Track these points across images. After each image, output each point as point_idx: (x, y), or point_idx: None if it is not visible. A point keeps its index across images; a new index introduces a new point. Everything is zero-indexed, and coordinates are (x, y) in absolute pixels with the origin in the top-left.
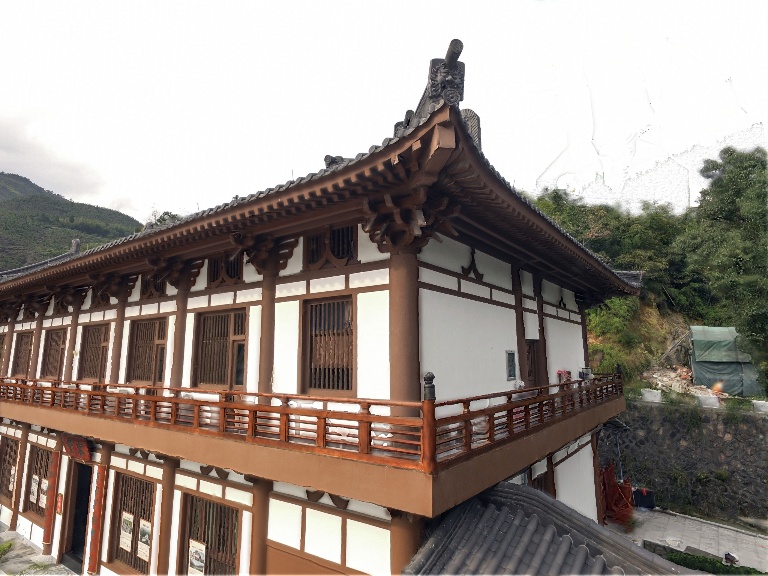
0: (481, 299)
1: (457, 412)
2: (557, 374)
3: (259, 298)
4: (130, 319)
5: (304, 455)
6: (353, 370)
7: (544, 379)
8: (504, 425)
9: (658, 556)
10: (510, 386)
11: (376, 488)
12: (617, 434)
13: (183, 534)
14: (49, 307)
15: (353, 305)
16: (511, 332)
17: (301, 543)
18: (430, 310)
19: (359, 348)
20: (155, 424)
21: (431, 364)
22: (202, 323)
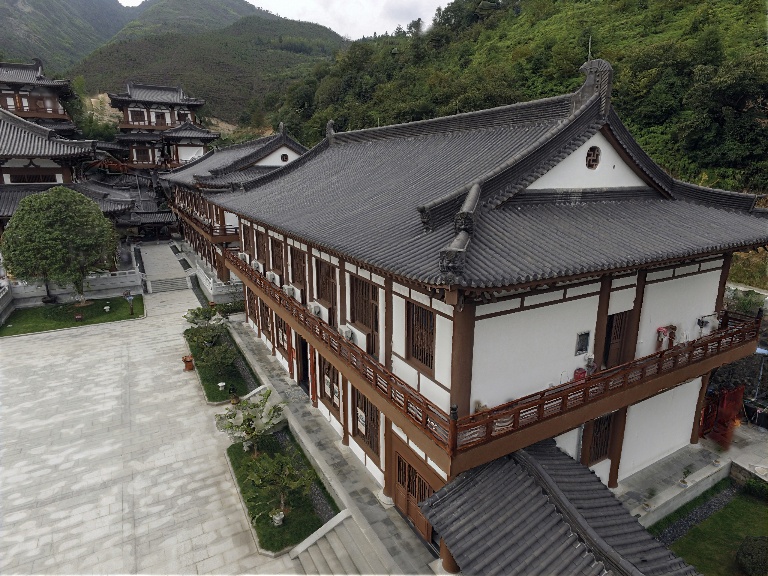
0: (550, 303)
1: (508, 392)
2: (656, 331)
3: (384, 285)
4: (315, 257)
5: (398, 412)
6: (433, 361)
7: (631, 342)
8: (533, 413)
9: (591, 529)
10: (578, 359)
11: (428, 448)
12: (763, 357)
13: (354, 403)
14: None
15: (434, 320)
16: (589, 316)
17: (407, 440)
18: (486, 332)
19: (436, 350)
20: (330, 349)
21: (484, 368)
22: (355, 282)
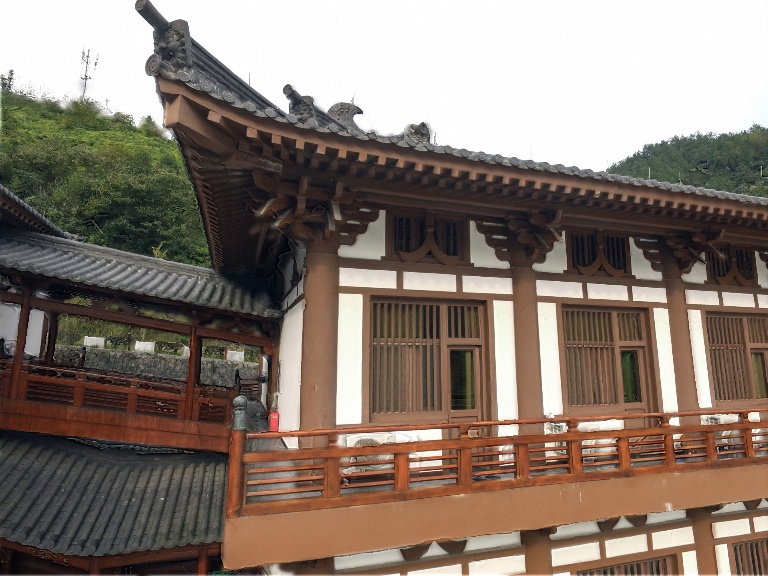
0: None
1: None
2: None
3: None
4: None
5: None
6: None
7: None
8: None
9: None
10: None
11: None
12: None
13: None
14: (694, 266)
15: None
16: None
17: None
18: None
19: None
20: None
21: None
22: None
